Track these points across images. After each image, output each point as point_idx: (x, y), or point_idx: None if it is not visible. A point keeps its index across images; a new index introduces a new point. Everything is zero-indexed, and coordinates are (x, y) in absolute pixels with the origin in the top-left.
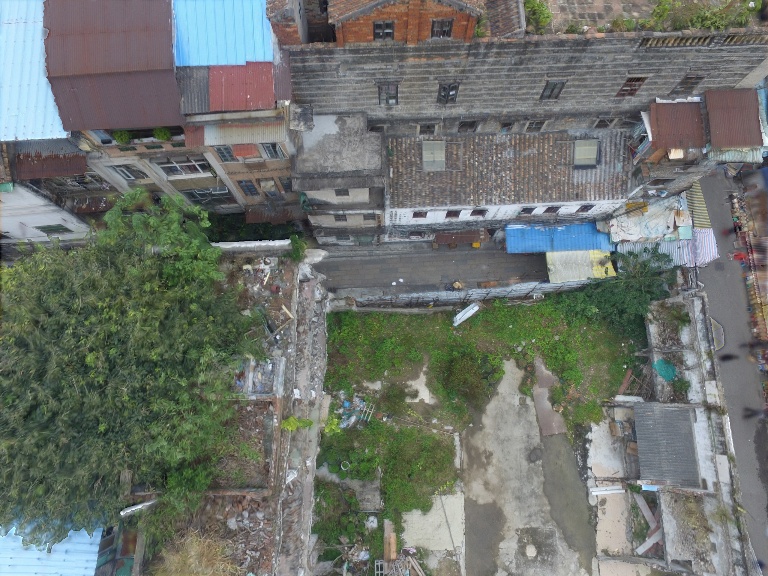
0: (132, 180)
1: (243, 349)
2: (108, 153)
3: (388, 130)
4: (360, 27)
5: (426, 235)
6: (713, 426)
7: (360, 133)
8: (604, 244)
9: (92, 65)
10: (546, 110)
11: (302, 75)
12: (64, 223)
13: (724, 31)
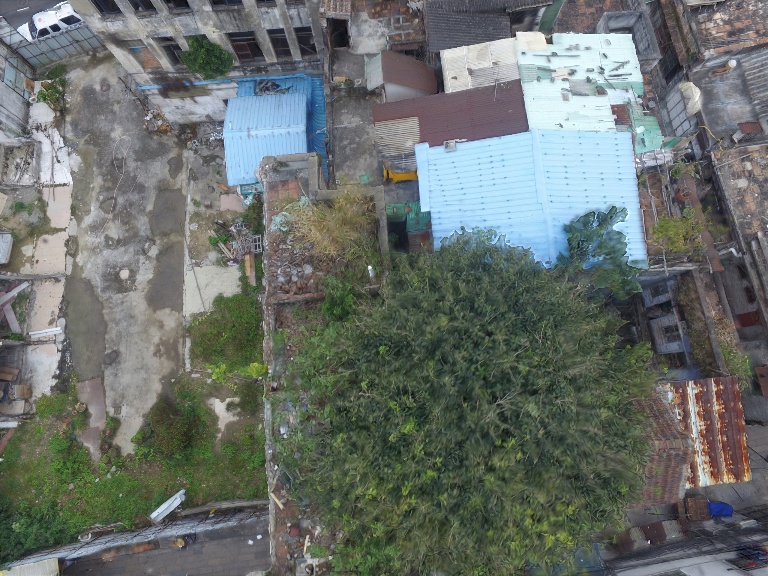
0: None
1: None
2: None
3: None
4: None
5: None
6: None
7: None
8: None
9: None
10: None
11: None
12: None
13: None
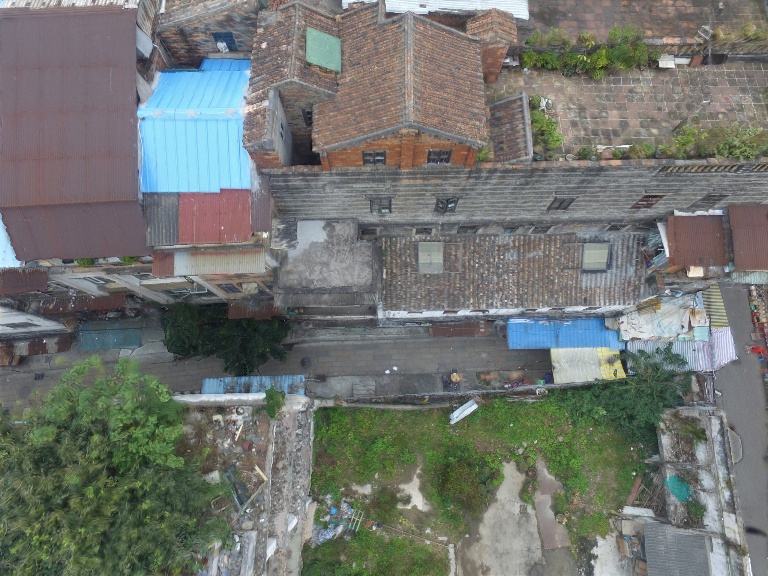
0: (102, 284)
1: (207, 530)
2: (71, 269)
3: (381, 231)
4: (348, 155)
5: (422, 324)
6: (732, 564)
7: (350, 241)
8: (613, 341)
9: (47, 195)
10: (553, 218)
11: (285, 191)
12: (30, 321)
13: (754, 160)
